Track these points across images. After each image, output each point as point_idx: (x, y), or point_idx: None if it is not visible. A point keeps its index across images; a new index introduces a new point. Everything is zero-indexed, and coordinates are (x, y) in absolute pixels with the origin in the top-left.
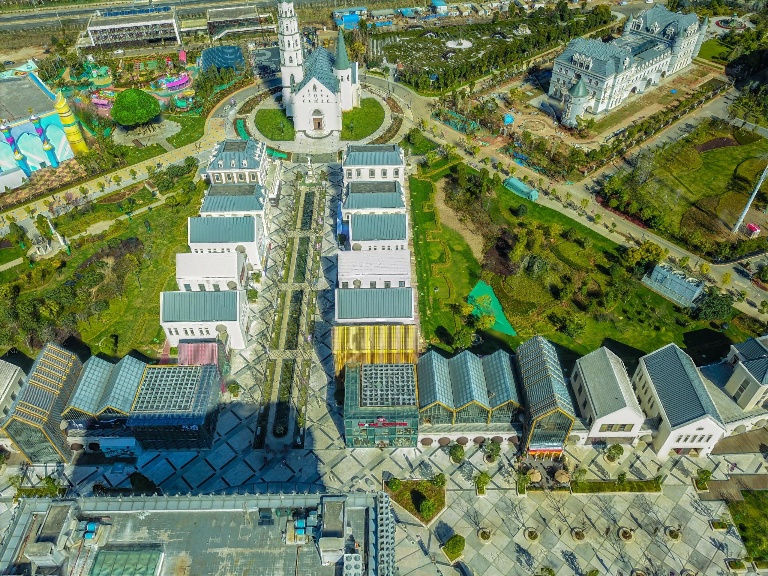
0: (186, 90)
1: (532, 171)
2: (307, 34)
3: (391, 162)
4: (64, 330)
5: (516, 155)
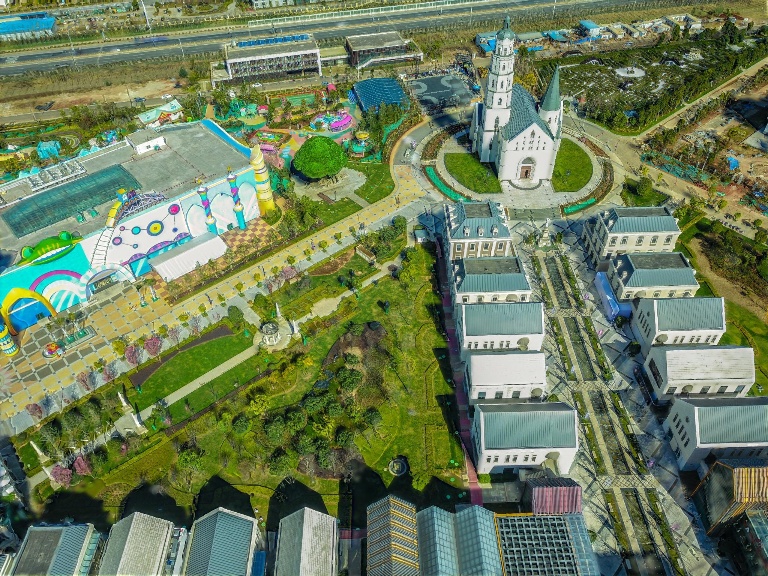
0: (358, 132)
1: None
2: (462, 63)
3: (665, 228)
4: (351, 455)
5: (764, 208)
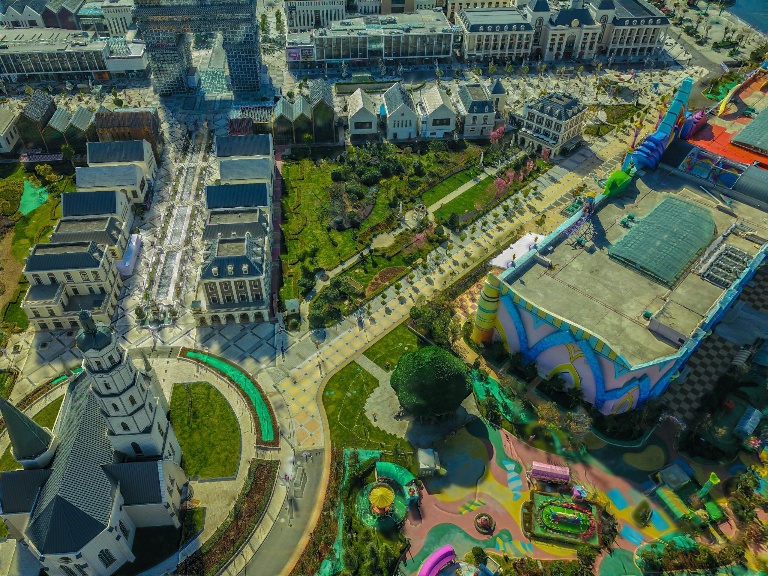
0: None
1: None
2: None
3: None
4: None
5: None
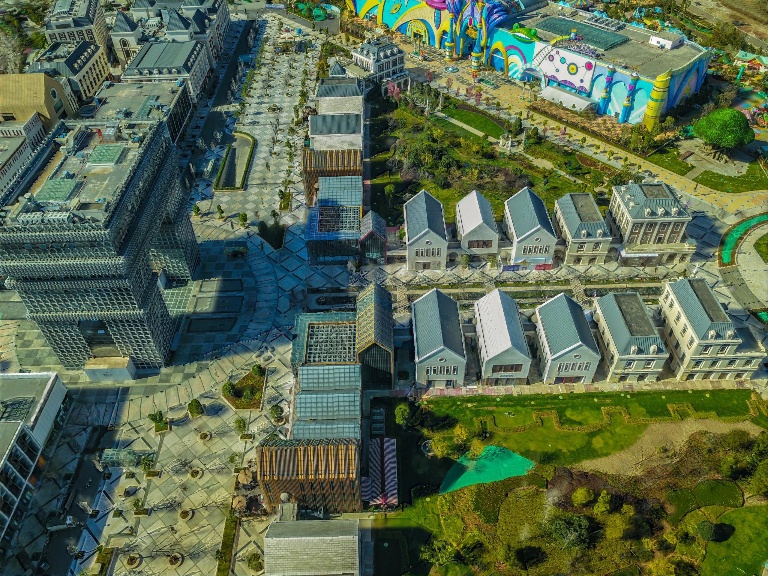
0: None
1: None
2: None
3: (697, 326)
4: None
5: None
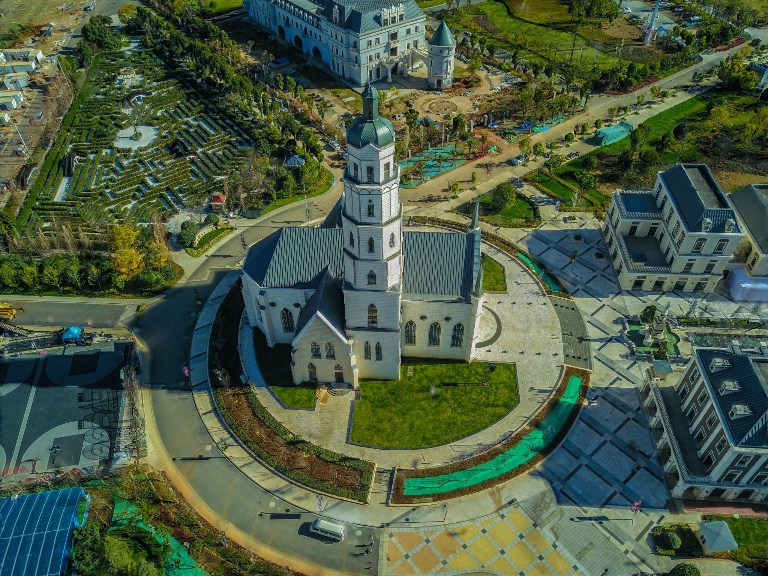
0: None
1: (562, 123)
2: None
3: None
4: None
5: (525, 128)
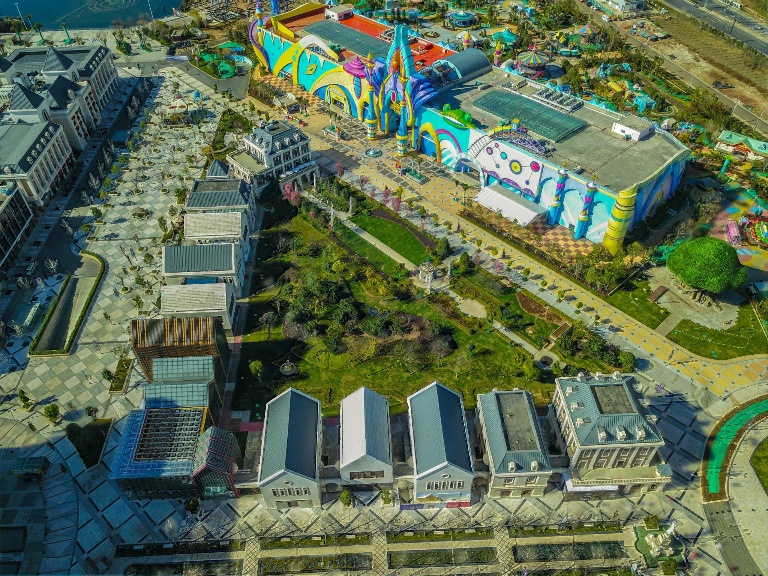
0: None
1: None
2: None
3: None
4: None
5: None
